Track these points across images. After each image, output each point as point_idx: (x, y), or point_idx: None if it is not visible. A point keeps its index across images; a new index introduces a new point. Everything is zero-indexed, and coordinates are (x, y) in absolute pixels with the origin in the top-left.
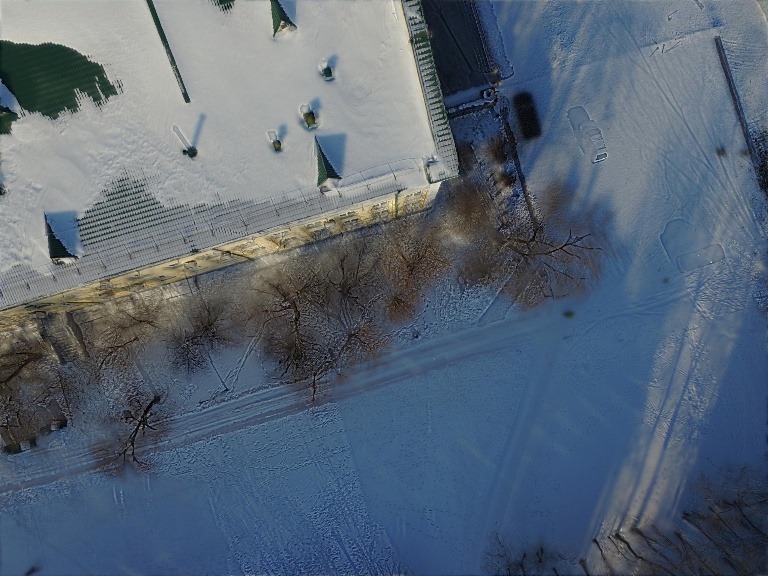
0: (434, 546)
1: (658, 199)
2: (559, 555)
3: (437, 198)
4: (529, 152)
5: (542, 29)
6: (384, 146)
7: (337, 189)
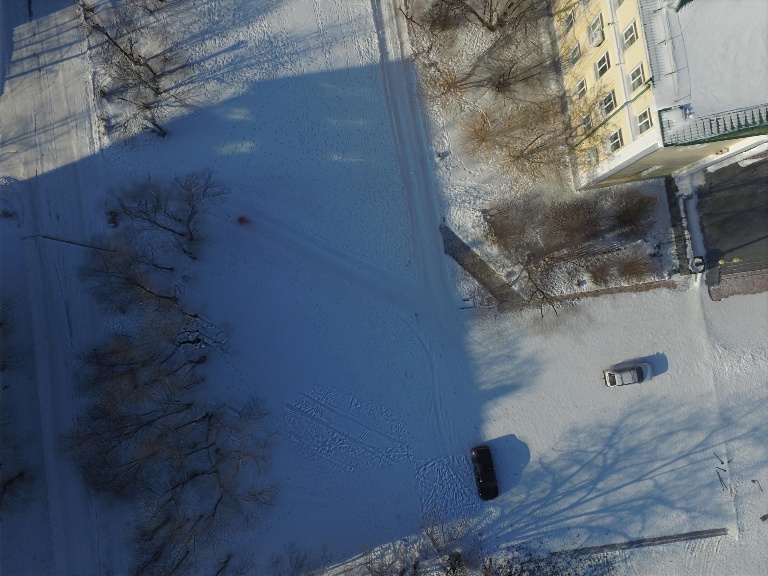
0: (213, 147)
1: (555, 438)
2: (186, 276)
3: (586, 199)
4: (624, 305)
5: (759, 339)
6: (709, 63)
7: (665, 7)
